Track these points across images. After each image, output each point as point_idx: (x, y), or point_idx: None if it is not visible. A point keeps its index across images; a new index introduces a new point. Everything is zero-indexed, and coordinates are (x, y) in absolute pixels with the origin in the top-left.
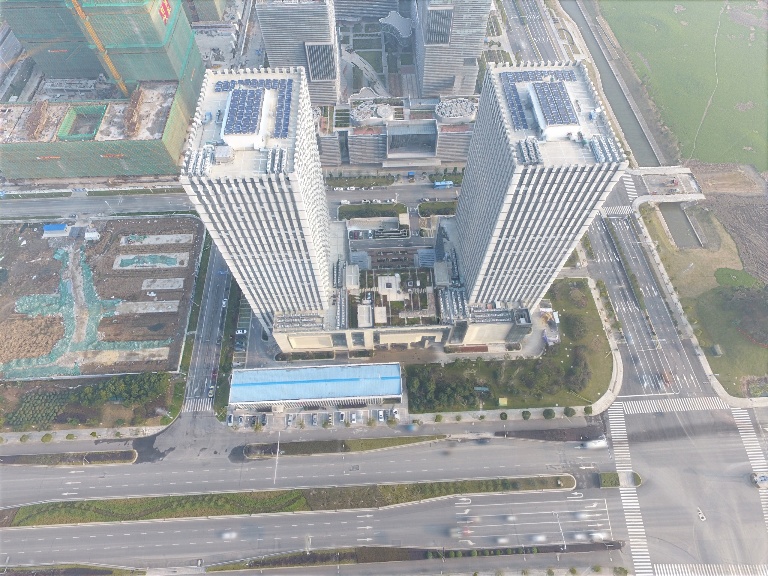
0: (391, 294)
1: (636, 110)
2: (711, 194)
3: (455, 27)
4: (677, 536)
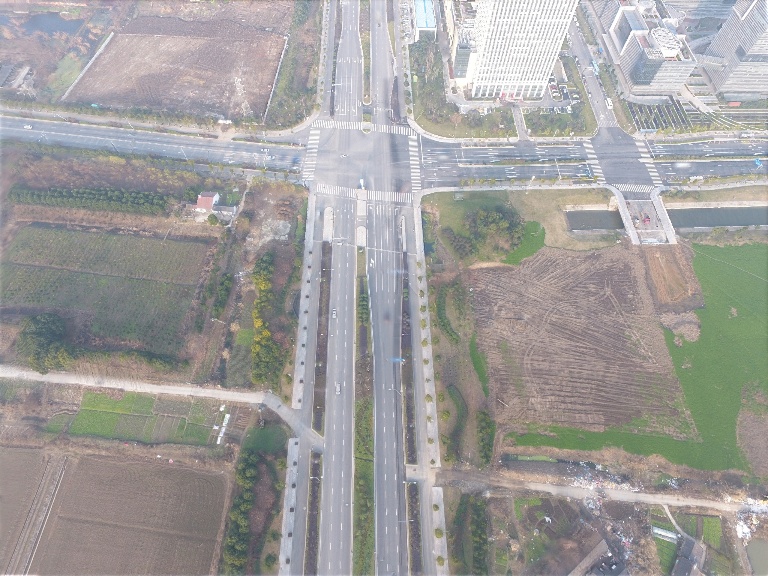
0: (476, 3)
1: (765, 227)
2: (642, 251)
3: (757, 6)
4: (334, 142)
